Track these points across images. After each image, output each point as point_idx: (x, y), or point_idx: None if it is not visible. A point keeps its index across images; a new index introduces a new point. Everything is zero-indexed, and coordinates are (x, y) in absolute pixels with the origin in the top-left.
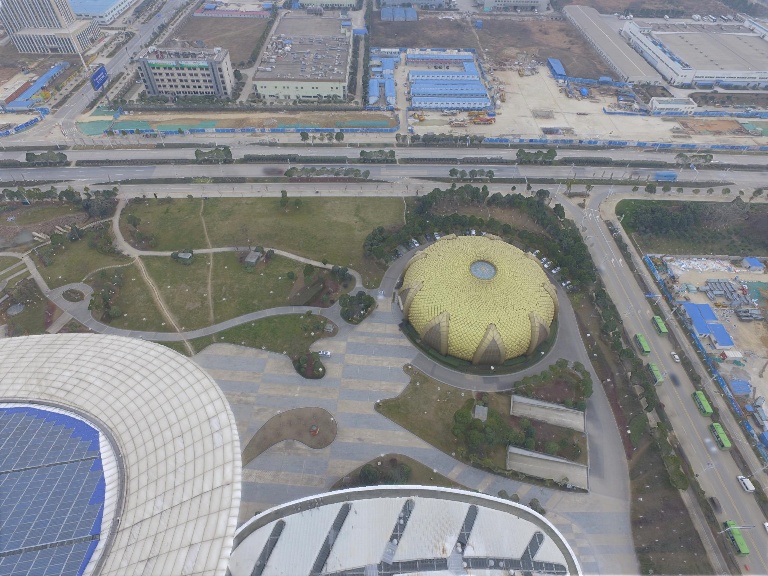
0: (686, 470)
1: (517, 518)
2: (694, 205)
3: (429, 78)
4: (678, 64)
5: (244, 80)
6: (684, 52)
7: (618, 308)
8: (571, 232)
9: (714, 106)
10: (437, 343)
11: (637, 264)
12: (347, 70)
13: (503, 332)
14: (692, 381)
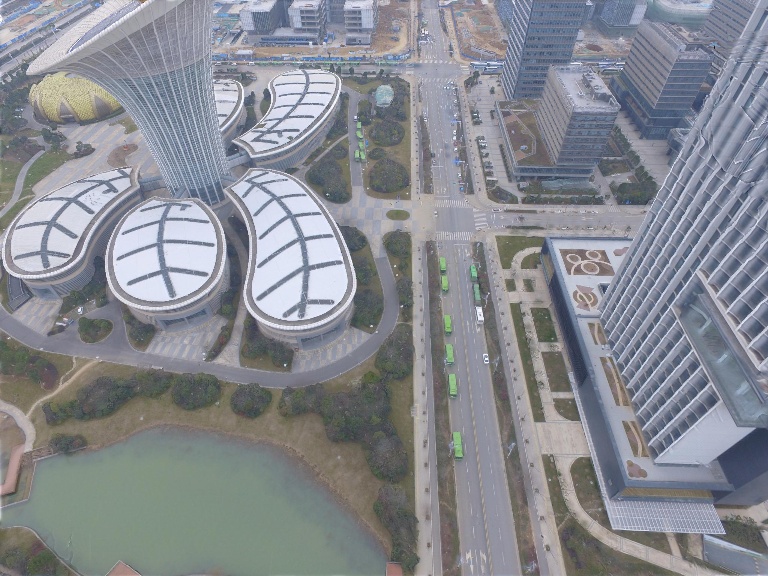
0: None
1: None
2: None
3: None
4: None
5: None
6: None
7: None
8: None
9: (5, 16)
10: (105, 107)
11: None
12: None
13: None
14: None
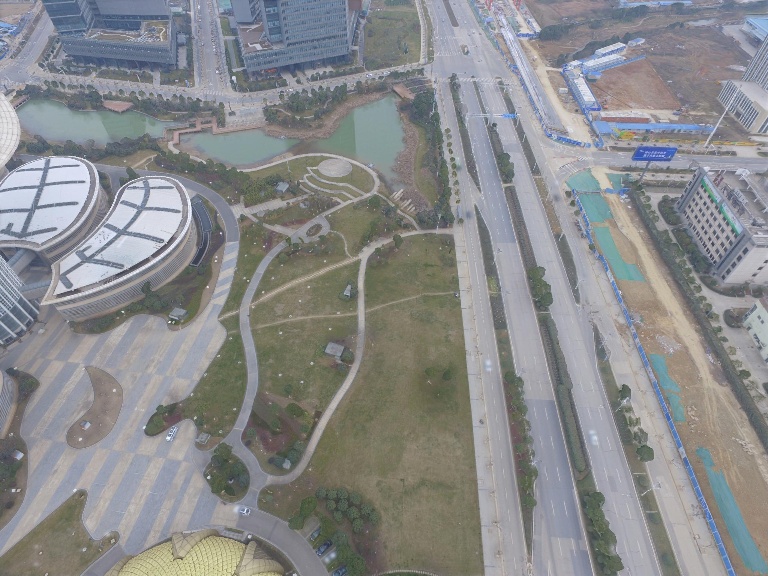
0: None
1: None
2: None
3: None
4: None
5: None
6: None
7: None
8: None
9: None
10: None
11: None
12: None
13: None
14: None
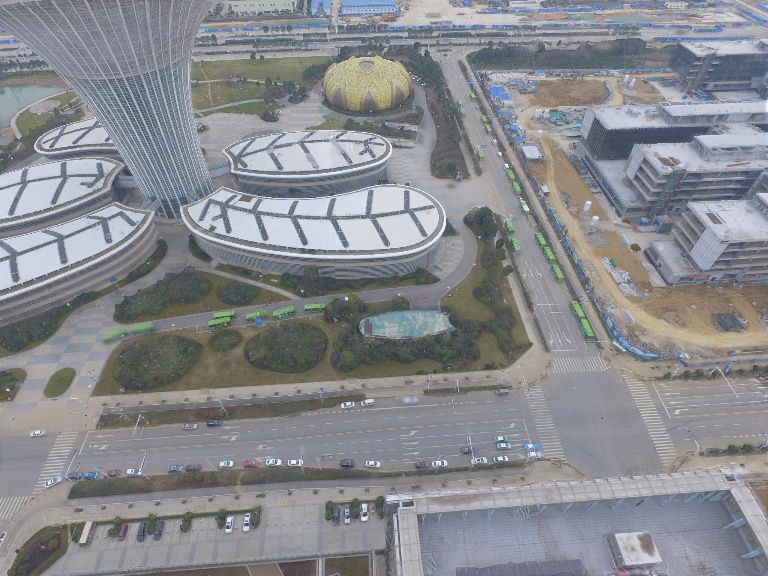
0: (466, 140)
1: None
2: None
3: None
4: None
5: (222, 6)
6: None
7: (452, 93)
8: (430, 60)
9: (556, 7)
10: (340, 101)
11: (471, 77)
12: None
13: (375, 89)
14: None
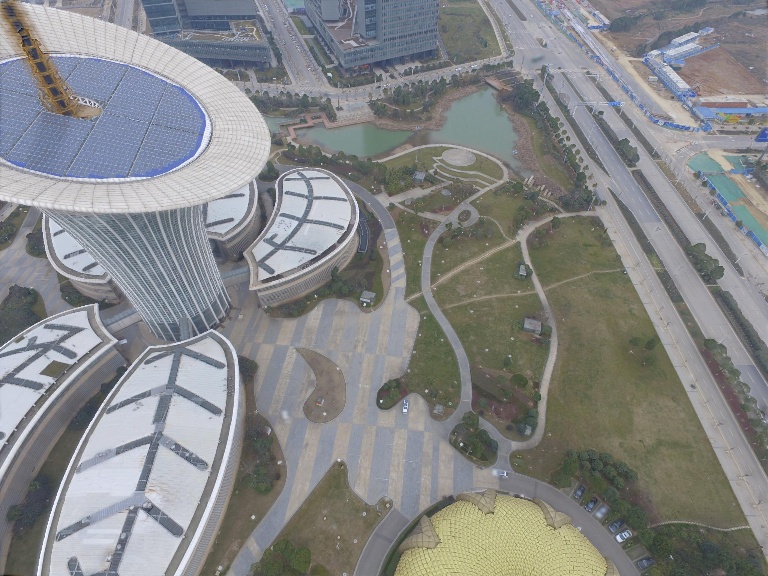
0: None
1: None
2: None
3: None
4: None
5: None
6: None
7: None
8: None
9: None
10: None
11: None
12: None
13: None
14: None
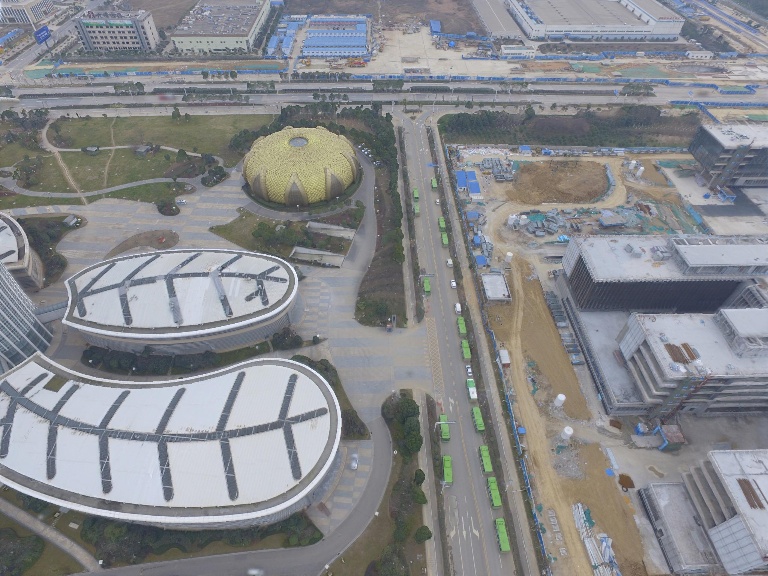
0: (413, 257)
1: (267, 260)
2: (492, 112)
3: (324, 35)
4: (533, 21)
5: (169, 40)
6: (545, 13)
7: (410, 177)
8: (389, 129)
9: (556, 53)
10: (260, 191)
11: (438, 152)
12: (253, 29)
13: (302, 178)
14: (443, 214)
